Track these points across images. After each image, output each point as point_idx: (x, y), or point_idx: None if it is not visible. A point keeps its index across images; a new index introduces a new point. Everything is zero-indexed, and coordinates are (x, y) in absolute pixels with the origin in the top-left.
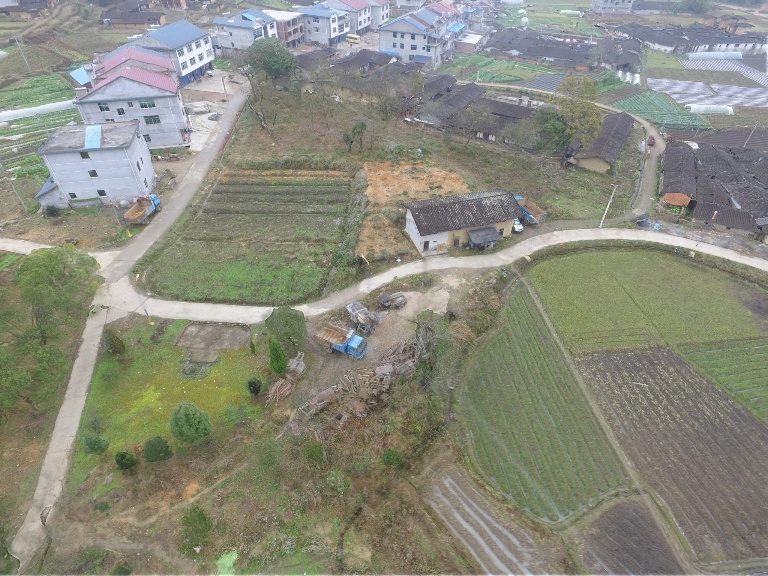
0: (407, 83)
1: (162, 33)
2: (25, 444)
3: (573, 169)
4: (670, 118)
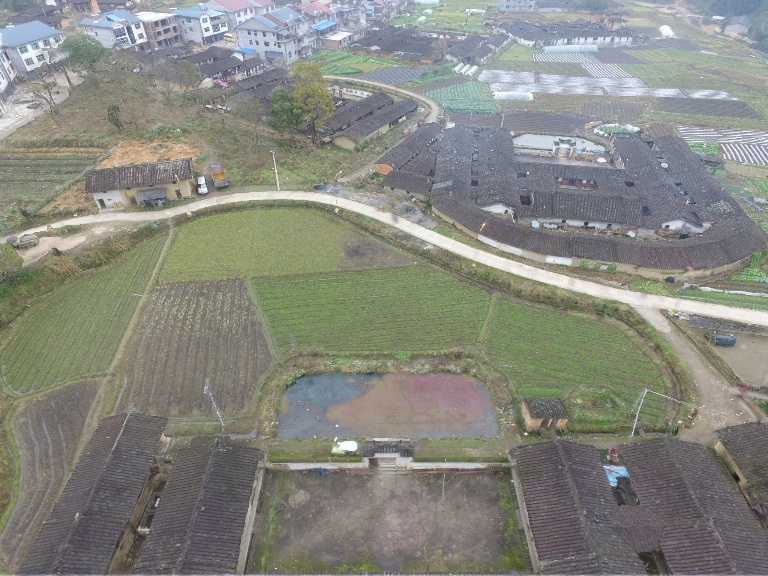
0: (177, 72)
1: (7, 33)
2: None
3: (328, 147)
4: (466, 104)
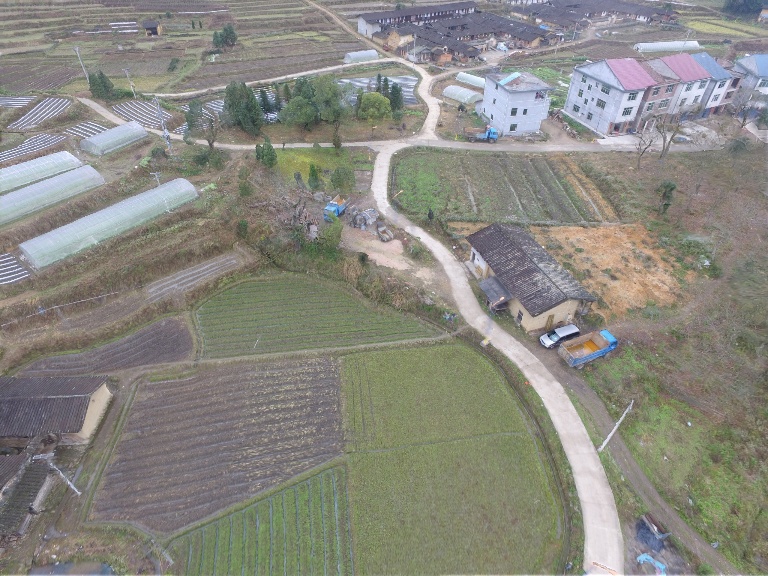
0: None
1: None
2: None
3: None
4: None
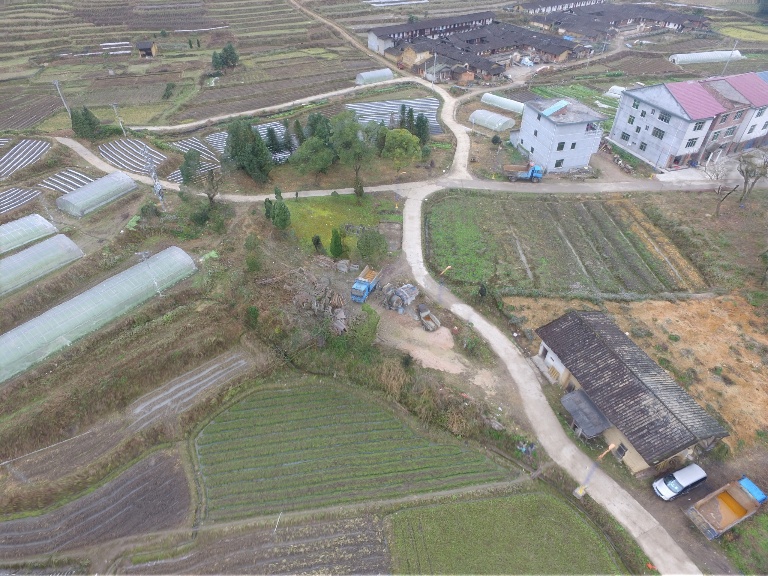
0: None
1: None
2: (298, 186)
3: None
4: None
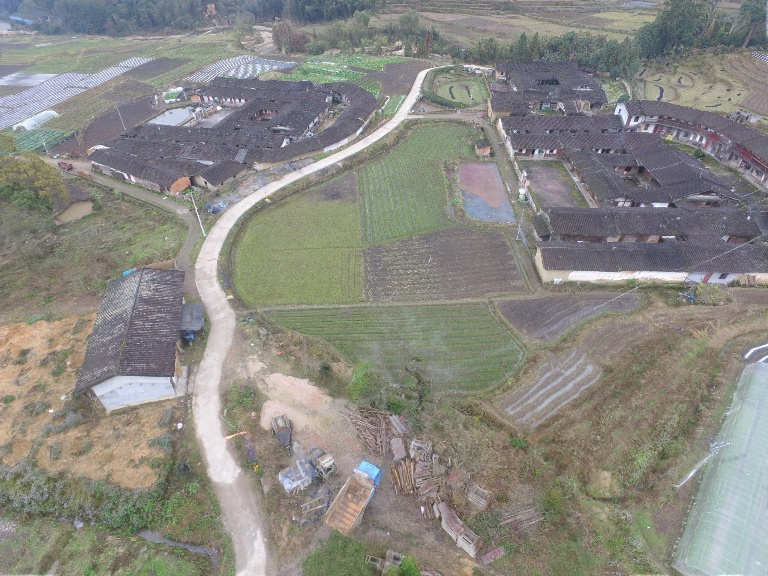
0: None
1: None
2: None
3: (64, 230)
4: (28, 143)
